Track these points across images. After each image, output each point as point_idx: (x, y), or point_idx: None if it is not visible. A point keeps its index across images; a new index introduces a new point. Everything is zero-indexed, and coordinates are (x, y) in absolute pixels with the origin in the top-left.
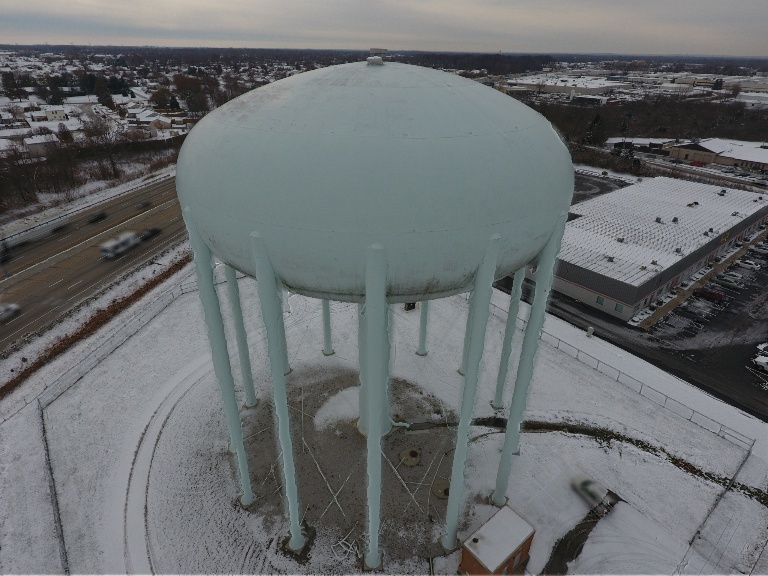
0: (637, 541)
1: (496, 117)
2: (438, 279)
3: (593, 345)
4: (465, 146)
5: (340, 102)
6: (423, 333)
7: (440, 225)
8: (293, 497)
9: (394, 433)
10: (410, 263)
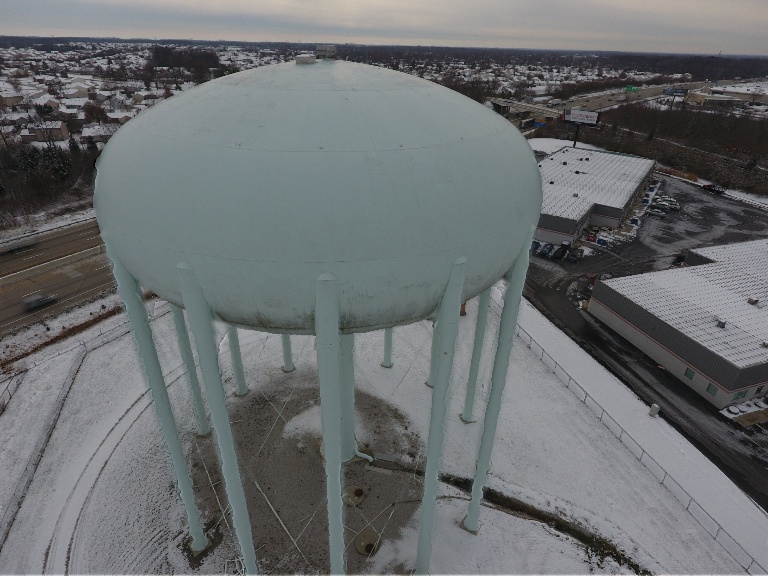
0: None
1: (383, 131)
2: (265, 314)
3: (652, 428)
4: (307, 163)
5: (210, 103)
6: (433, 363)
7: (249, 253)
8: (185, 499)
9: (353, 463)
10: (223, 291)
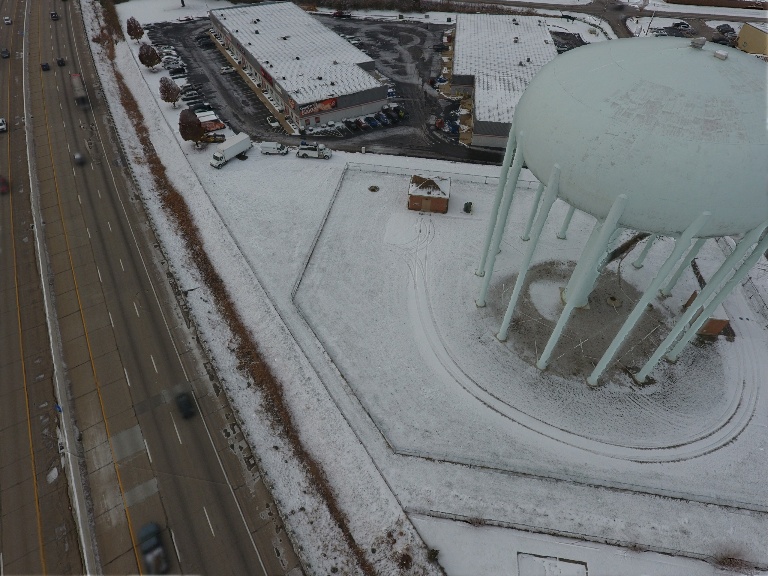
0: None
1: None
2: None
3: None
4: None
5: None
6: None
7: None
8: None
9: (588, 295)
10: None
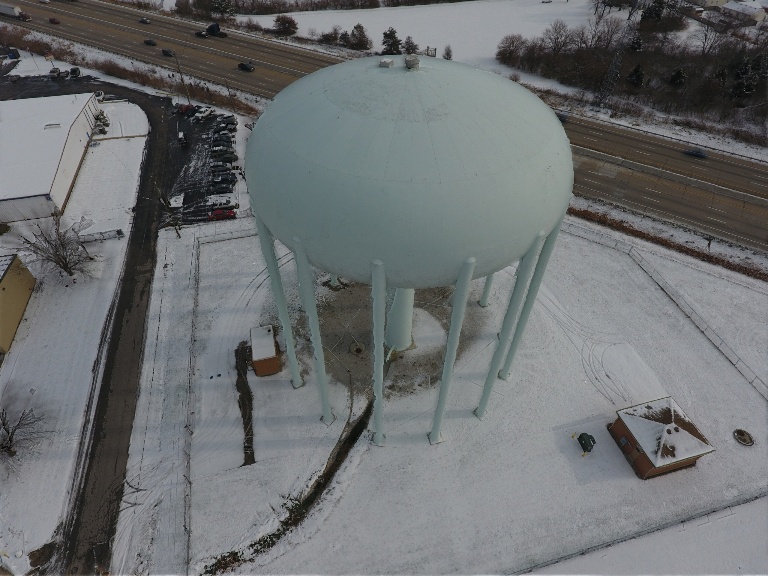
0: (218, 446)
1: (285, 117)
2: None
3: None
4: None
5: None
6: None
7: None
8: None
9: (385, 348)
10: None
